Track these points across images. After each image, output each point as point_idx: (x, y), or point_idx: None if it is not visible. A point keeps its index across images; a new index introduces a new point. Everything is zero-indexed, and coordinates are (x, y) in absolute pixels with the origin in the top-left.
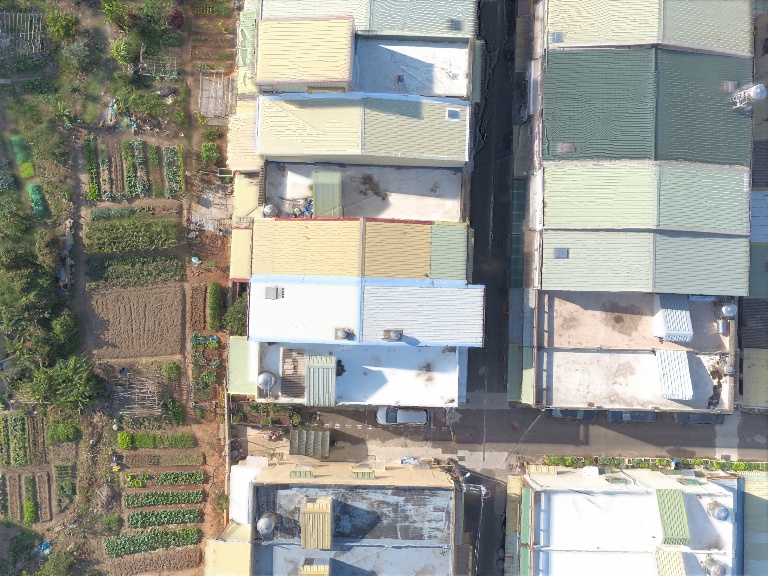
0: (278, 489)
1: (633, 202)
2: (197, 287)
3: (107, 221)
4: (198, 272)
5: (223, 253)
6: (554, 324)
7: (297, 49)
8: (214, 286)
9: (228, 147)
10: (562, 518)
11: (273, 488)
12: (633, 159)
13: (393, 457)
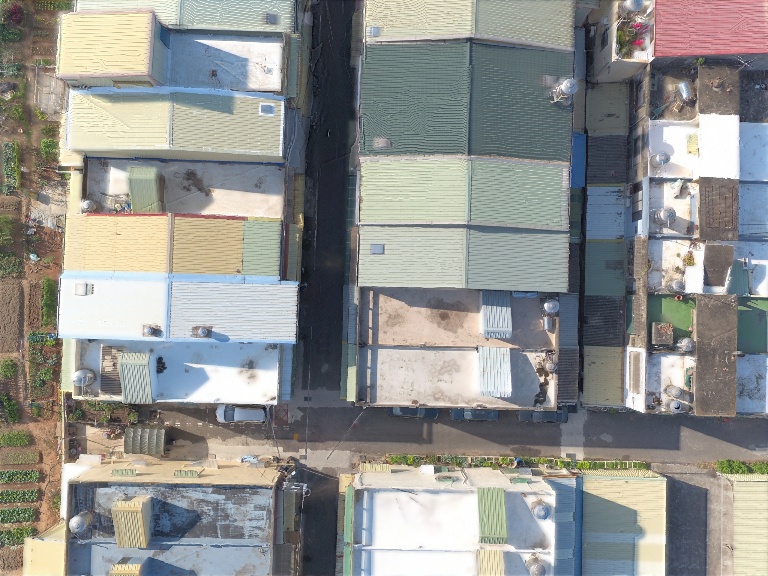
0: (97, 487)
1: (445, 197)
2: (35, 284)
3: None
4: (36, 269)
5: (62, 250)
6: (379, 321)
7: (100, 43)
8: (47, 283)
9: (60, 143)
10: (385, 517)
11: (92, 486)
12: (447, 154)
13: (234, 456)
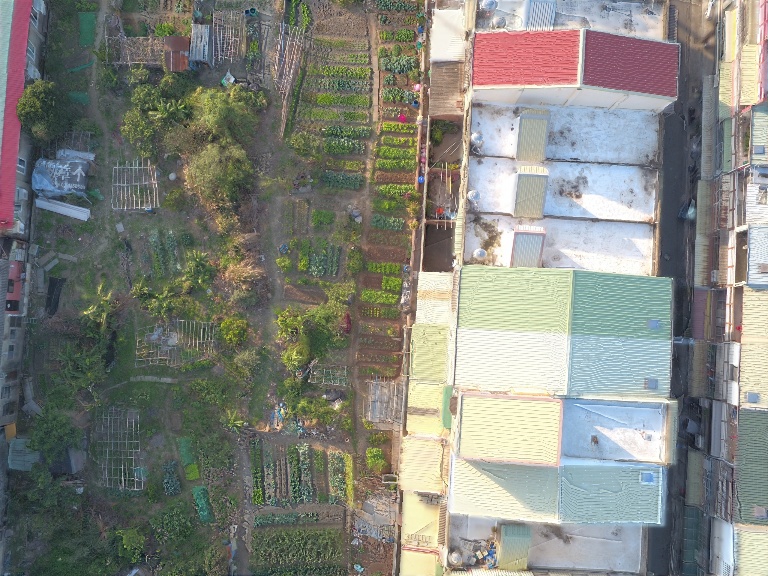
0: None
1: None
2: None
3: (273, 531)
4: None
5: (385, 560)
6: None
7: (501, 426)
8: None
9: (401, 468)
10: None
11: None
12: None
13: None
